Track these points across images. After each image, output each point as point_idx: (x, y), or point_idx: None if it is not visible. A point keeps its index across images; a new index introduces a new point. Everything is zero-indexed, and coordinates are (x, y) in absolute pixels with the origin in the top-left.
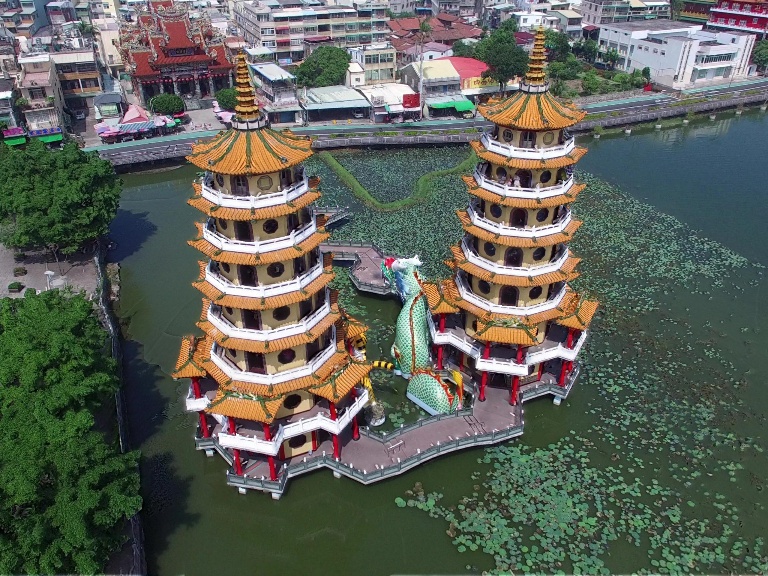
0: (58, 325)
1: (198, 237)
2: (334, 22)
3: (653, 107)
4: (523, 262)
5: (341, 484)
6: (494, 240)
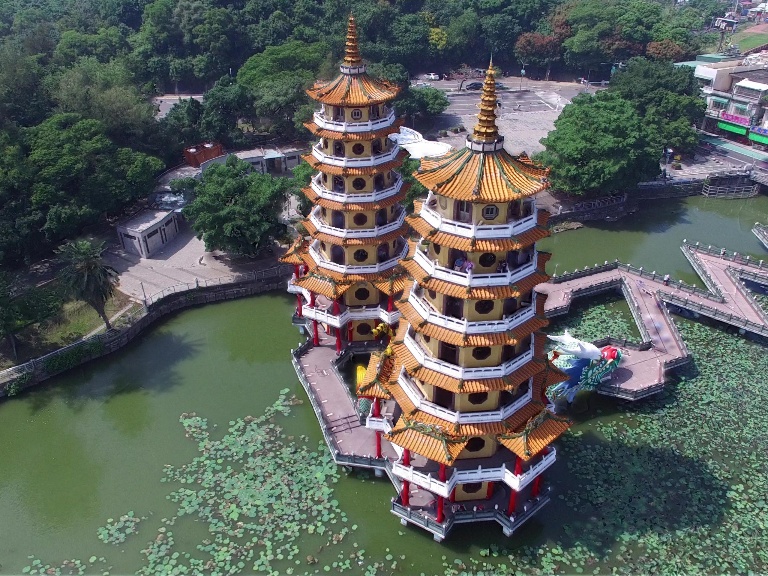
0: None
1: None
2: None
3: None
4: None
5: None
6: None
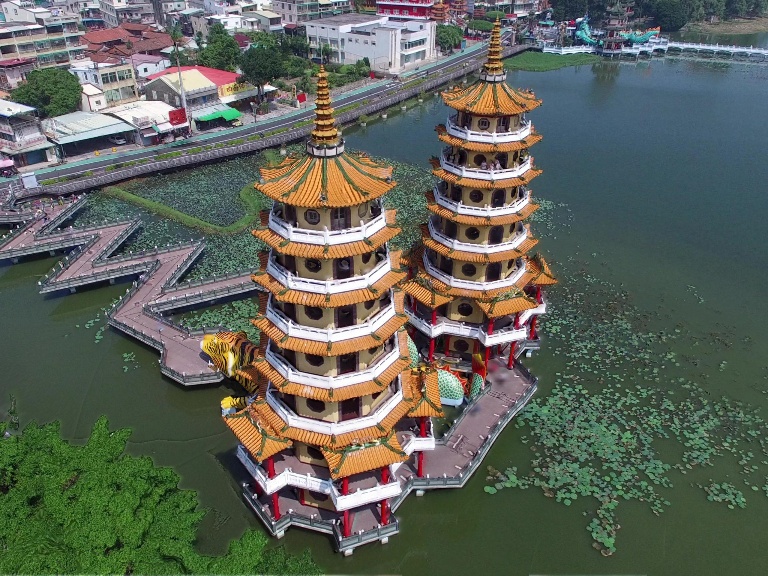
0: (108, 455)
1: (284, 289)
2: (19, 41)
3: (390, 92)
4: (503, 237)
5: (426, 500)
6: (490, 222)
